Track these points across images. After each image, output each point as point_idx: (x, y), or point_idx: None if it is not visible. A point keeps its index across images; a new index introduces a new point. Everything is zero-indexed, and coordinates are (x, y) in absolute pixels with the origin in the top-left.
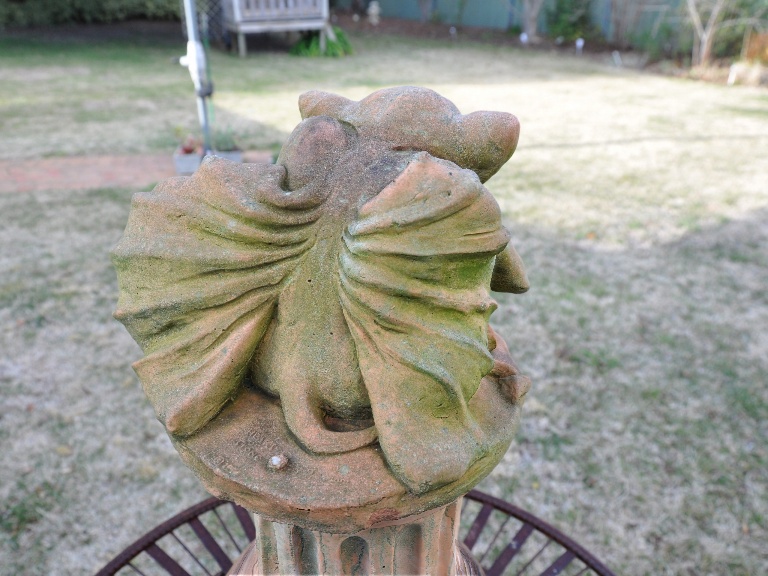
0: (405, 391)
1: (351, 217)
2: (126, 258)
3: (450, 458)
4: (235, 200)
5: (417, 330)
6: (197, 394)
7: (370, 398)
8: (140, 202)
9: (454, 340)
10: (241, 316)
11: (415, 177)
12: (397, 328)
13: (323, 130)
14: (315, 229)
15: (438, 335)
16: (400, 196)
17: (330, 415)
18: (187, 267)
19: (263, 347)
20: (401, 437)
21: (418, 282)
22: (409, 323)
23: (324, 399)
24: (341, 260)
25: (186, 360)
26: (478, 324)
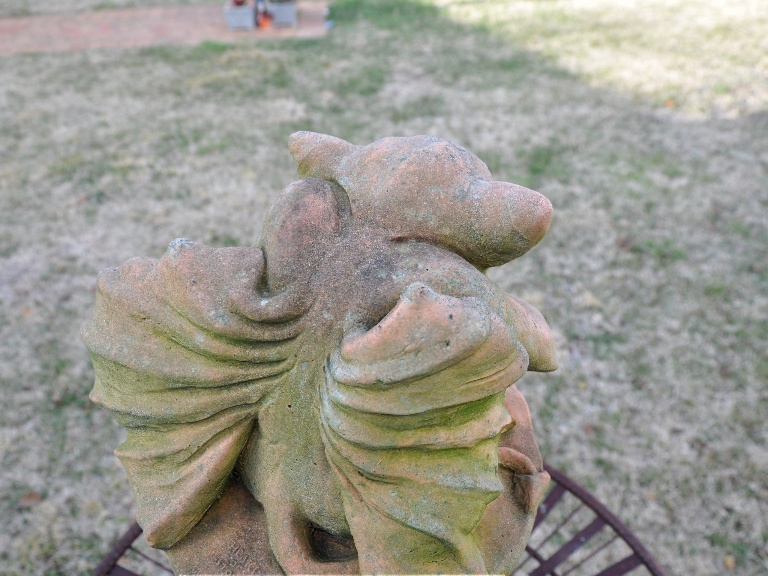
0: (393, 543)
1: (335, 341)
2: (93, 353)
3: None
4: (202, 311)
5: (408, 481)
6: (175, 509)
7: (355, 545)
8: (103, 290)
9: (452, 487)
10: (217, 433)
11: (406, 323)
12: (385, 480)
13: (309, 209)
14: (295, 348)
15: (433, 484)
16: (386, 346)
17: (319, 529)
18: (154, 381)
19: (246, 453)
20: None
21: (410, 431)
22: (399, 475)
23: (311, 520)
24: (321, 398)
25: (164, 467)
26: (485, 453)
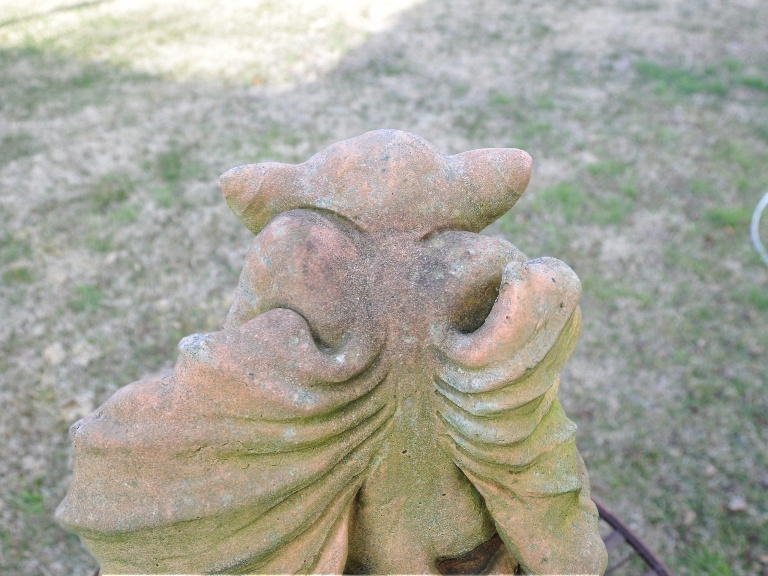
0: (548, 520)
1: (434, 361)
2: (123, 533)
3: (598, 555)
4: (283, 402)
5: (544, 454)
6: None
7: (516, 545)
8: (108, 448)
9: (567, 440)
10: (329, 529)
11: (527, 303)
12: (530, 466)
13: (324, 243)
14: (391, 389)
15: (557, 445)
16: (521, 334)
17: None
18: (245, 513)
19: None
20: (559, 566)
21: None
22: (539, 454)
23: (440, 556)
24: (451, 421)
25: None
26: None
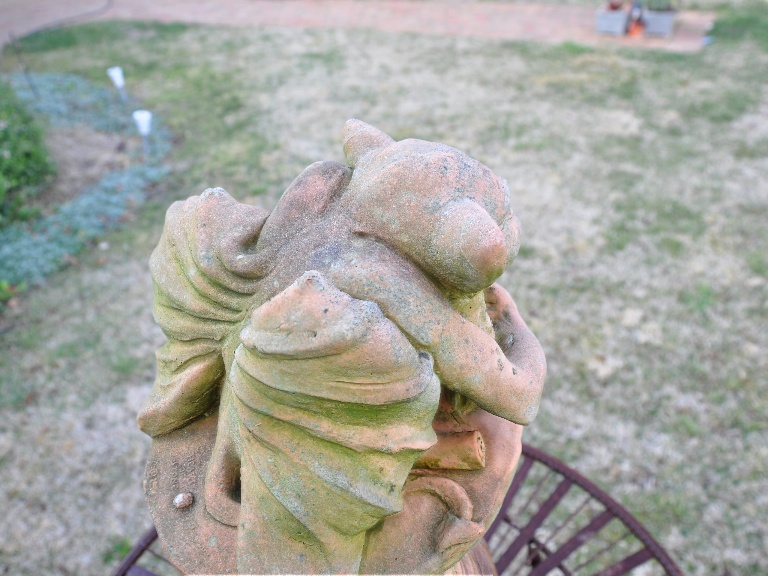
0: (264, 505)
1: None
2: None
3: None
4: (197, 250)
5: (284, 454)
6: (160, 407)
7: None
8: None
9: (323, 478)
10: (195, 356)
11: (288, 303)
12: (264, 444)
13: (307, 187)
14: (248, 303)
15: (306, 467)
16: (269, 319)
17: None
18: (164, 296)
19: None
20: (248, 545)
21: (290, 408)
22: (275, 444)
23: None
24: None
25: None
26: (379, 465)
